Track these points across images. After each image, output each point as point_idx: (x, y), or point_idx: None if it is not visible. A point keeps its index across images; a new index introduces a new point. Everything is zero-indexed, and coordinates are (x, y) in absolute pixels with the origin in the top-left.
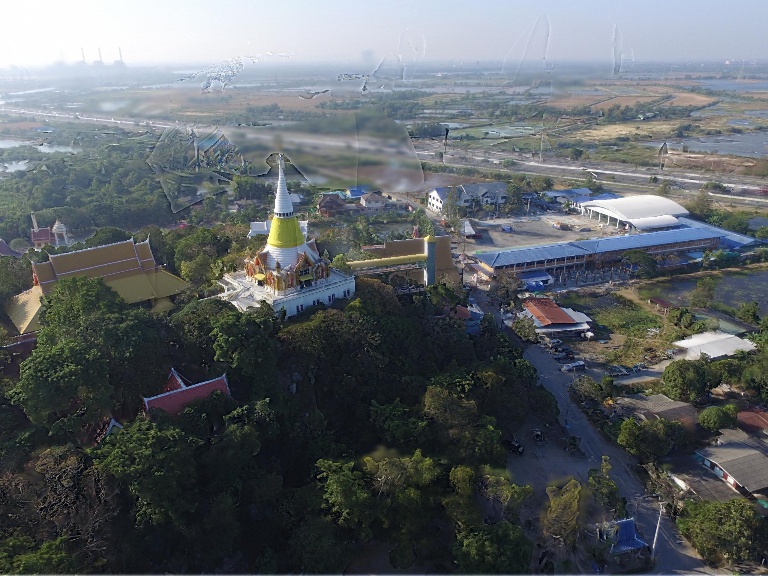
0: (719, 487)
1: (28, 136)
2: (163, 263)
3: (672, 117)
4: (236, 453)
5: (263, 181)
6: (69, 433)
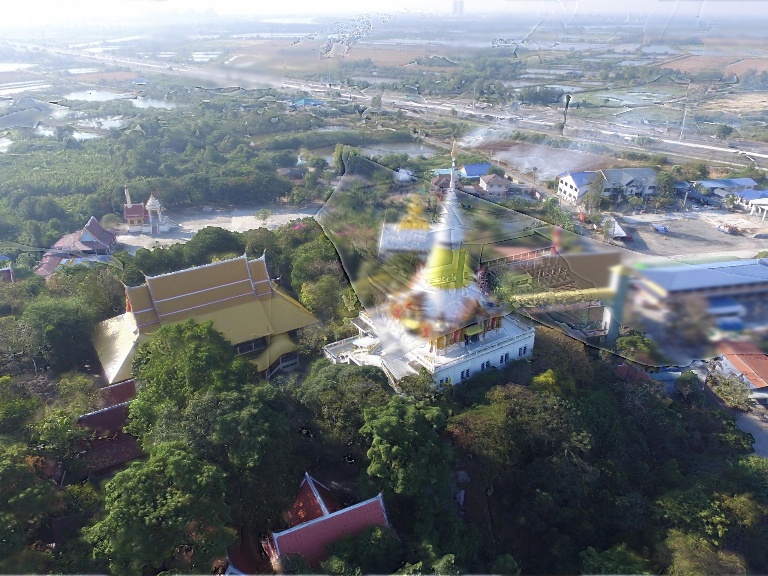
0: None
1: (123, 88)
2: (275, 275)
3: None
4: None
5: (368, 153)
6: (168, 561)
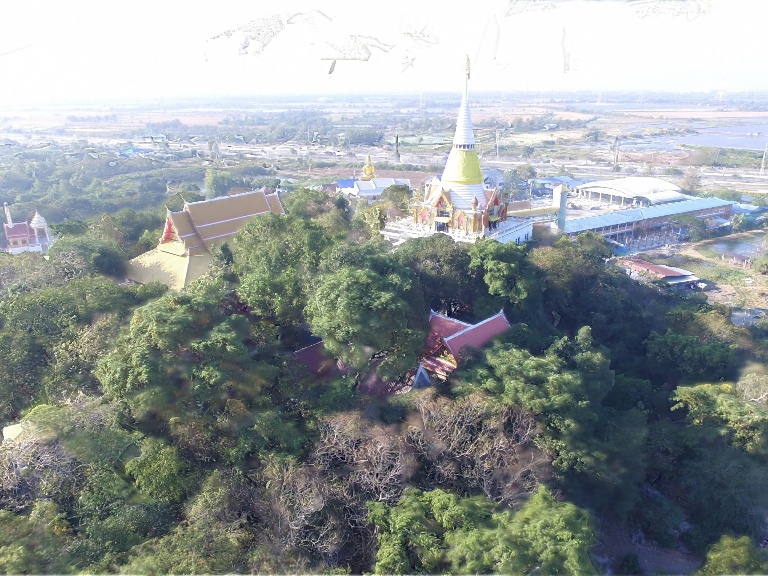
0: None
1: None
2: None
3: (572, 128)
4: (600, 385)
5: (240, 177)
6: None
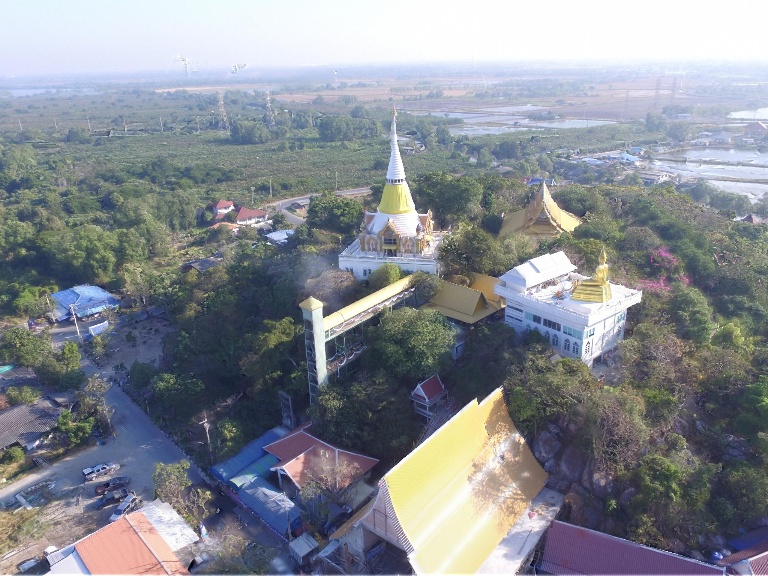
0: (6, 377)
1: None
2: None
3: None
4: None
5: None
6: None
